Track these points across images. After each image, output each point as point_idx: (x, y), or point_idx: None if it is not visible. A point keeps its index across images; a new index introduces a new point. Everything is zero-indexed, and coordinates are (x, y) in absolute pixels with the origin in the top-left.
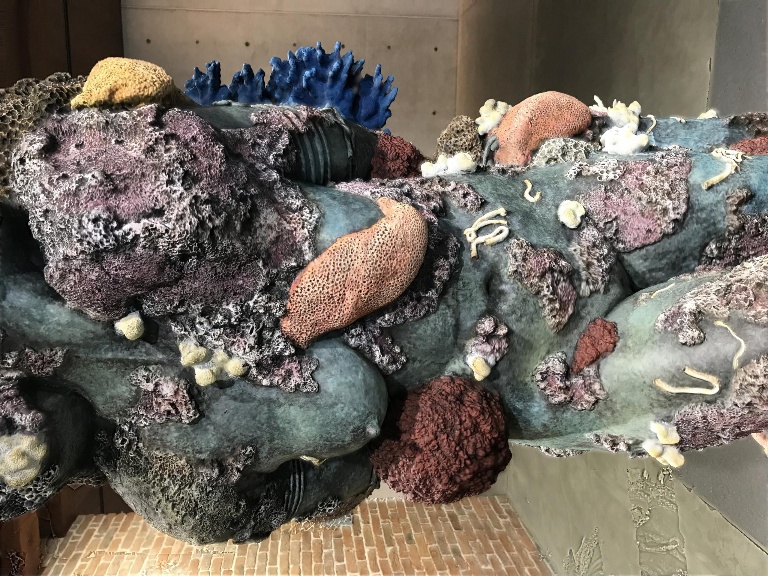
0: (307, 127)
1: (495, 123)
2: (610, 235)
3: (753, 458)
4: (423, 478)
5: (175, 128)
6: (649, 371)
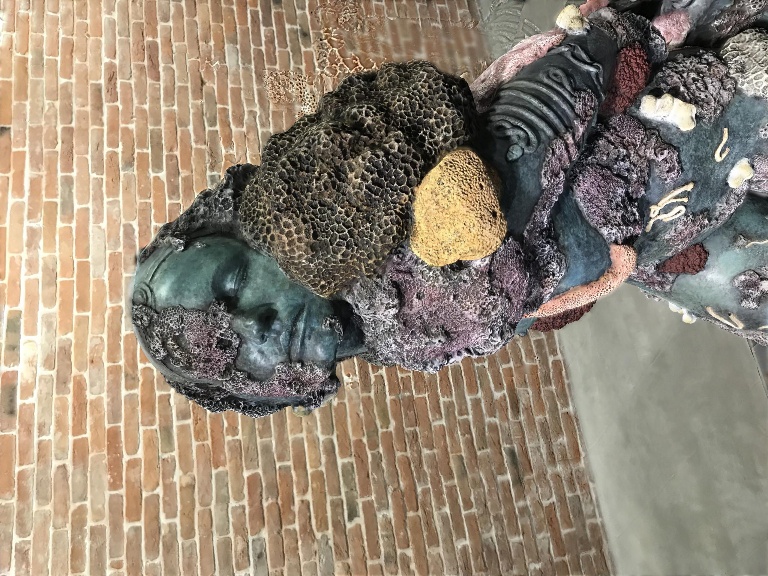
0: None
1: None
2: (755, 186)
3: None
4: None
5: (501, 278)
6: (708, 301)
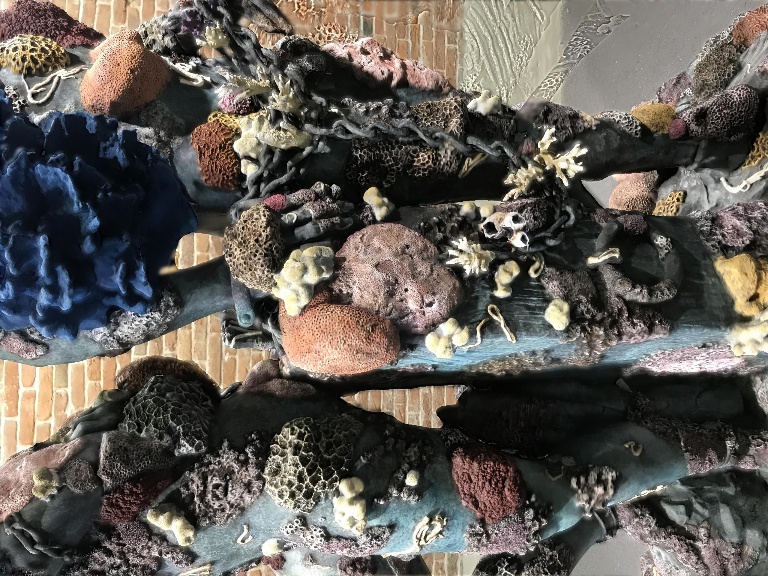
0: None
1: None
2: None
3: (604, 93)
4: None
5: None
6: None
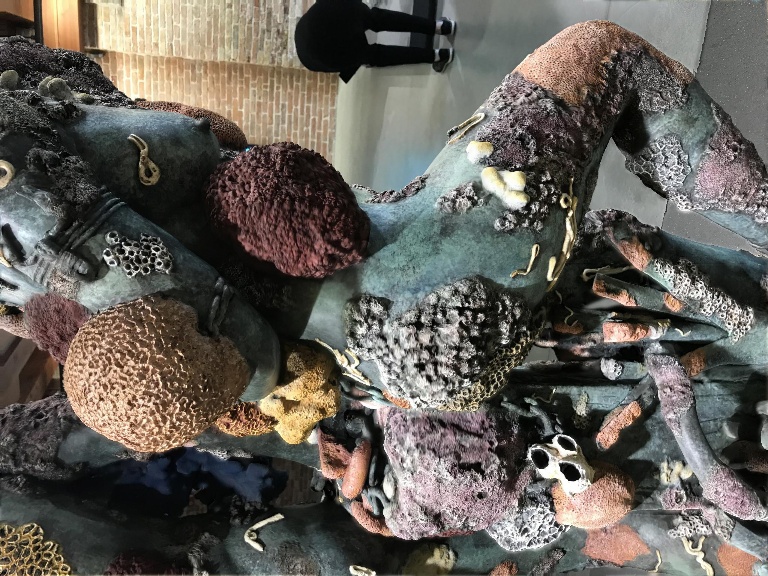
0: None
1: None
2: None
3: None
4: (258, 149)
5: None
6: None
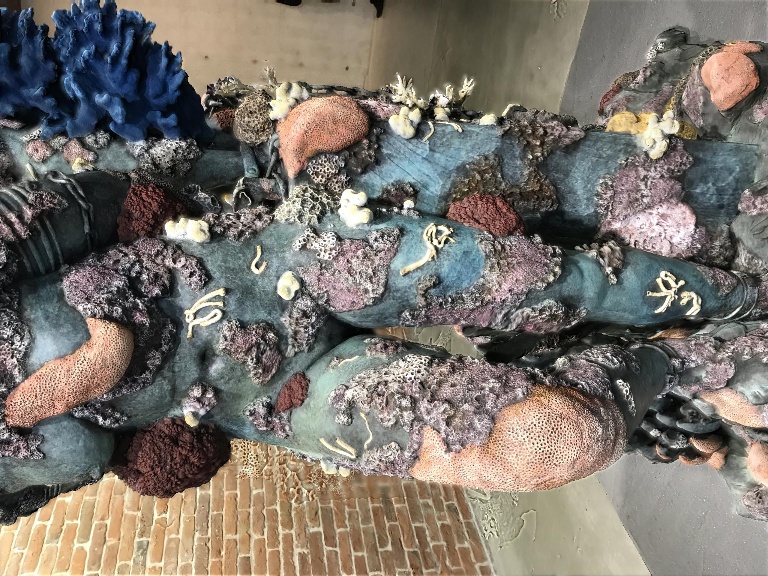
0: (31, 228)
1: (282, 116)
2: (322, 303)
3: None
4: None
5: None
6: (318, 431)
